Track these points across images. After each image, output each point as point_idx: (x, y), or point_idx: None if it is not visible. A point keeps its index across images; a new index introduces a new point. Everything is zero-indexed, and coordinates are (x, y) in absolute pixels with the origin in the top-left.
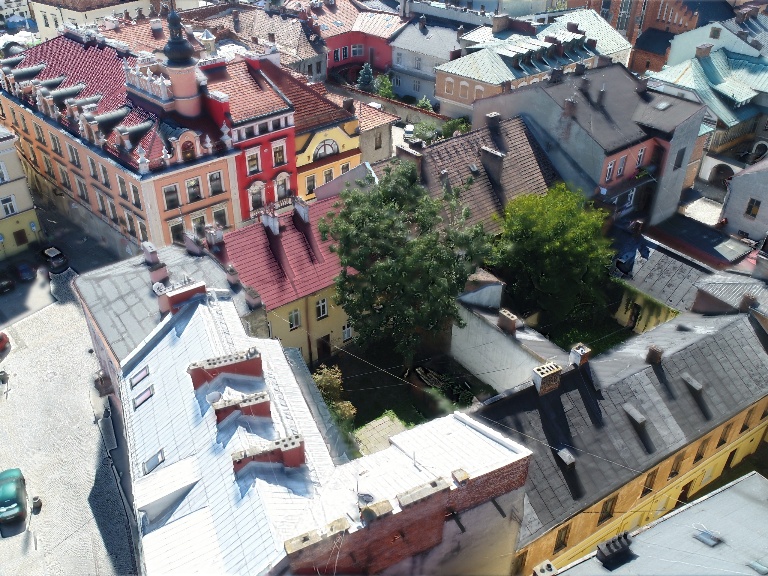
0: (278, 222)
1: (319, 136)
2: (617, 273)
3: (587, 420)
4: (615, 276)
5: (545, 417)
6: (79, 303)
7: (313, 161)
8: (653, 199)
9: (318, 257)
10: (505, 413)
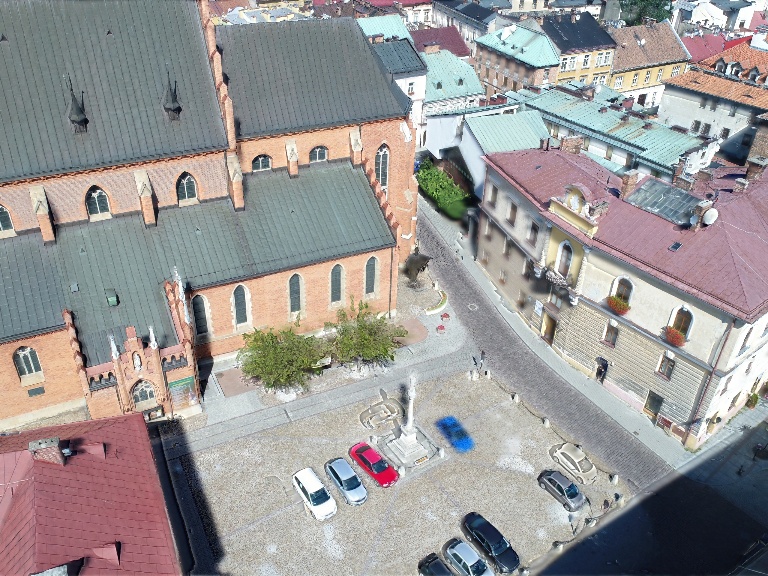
0: (695, 33)
1: None
2: None
3: None
4: None
5: None
6: None
7: None
8: None
9: None
10: None
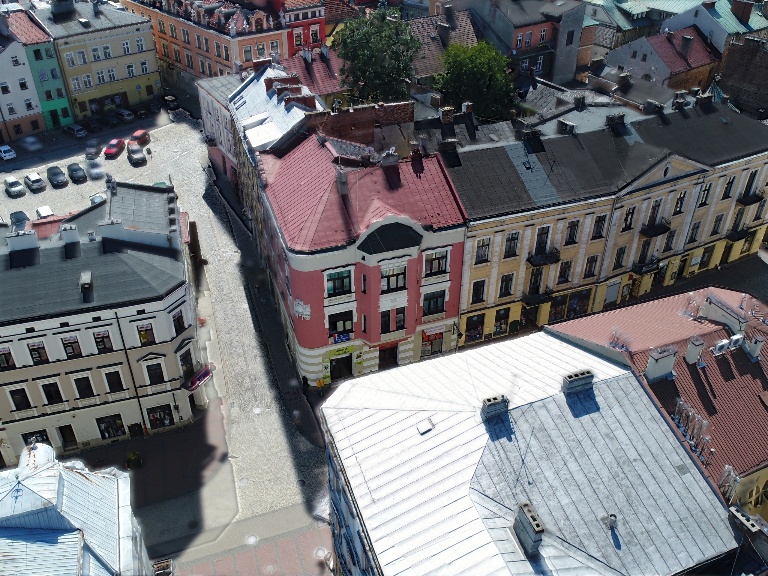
0: None
1: (341, 26)
2: (518, 99)
3: (467, 138)
4: (516, 101)
5: (444, 133)
6: (188, 123)
7: (337, 44)
8: (553, 65)
9: (334, 76)
10: (422, 128)
